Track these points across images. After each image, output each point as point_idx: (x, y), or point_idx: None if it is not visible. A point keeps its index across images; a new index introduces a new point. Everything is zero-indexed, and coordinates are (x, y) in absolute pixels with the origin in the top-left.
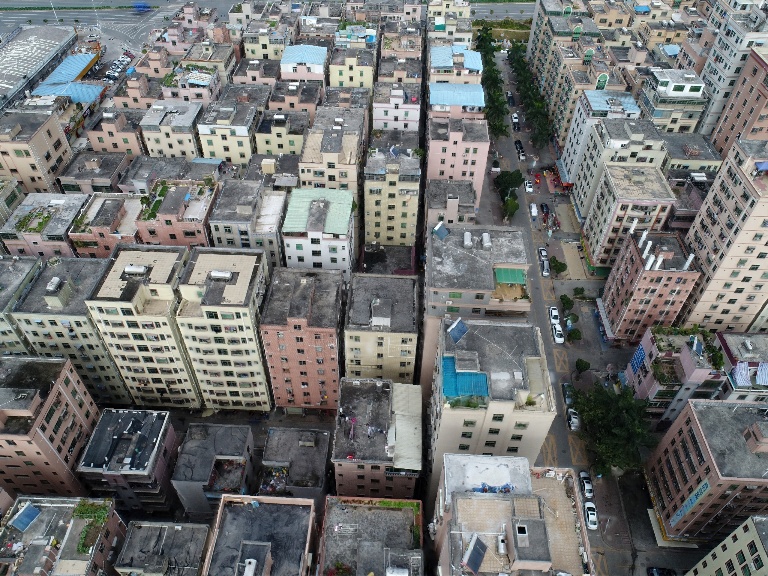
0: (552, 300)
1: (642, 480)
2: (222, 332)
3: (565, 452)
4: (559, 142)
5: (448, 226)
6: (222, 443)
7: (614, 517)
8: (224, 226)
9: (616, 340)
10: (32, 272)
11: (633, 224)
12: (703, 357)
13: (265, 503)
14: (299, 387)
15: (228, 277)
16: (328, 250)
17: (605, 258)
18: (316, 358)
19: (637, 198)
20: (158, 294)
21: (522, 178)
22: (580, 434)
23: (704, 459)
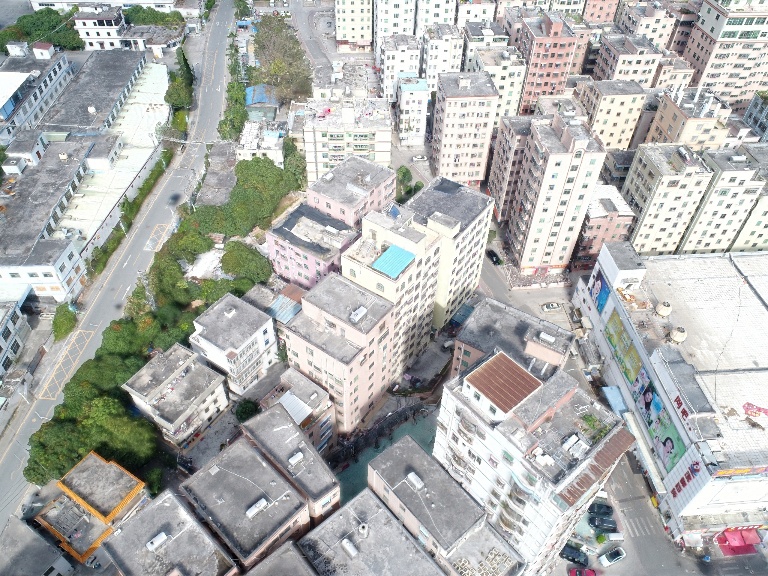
0: None
1: None
2: None
3: None
4: None
5: None
6: None
7: None
8: None
9: None
10: None
11: None
12: None
13: (640, 6)
14: (595, 20)
15: None
16: None
17: None
18: None
19: None
20: None
21: None
22: None
23: None
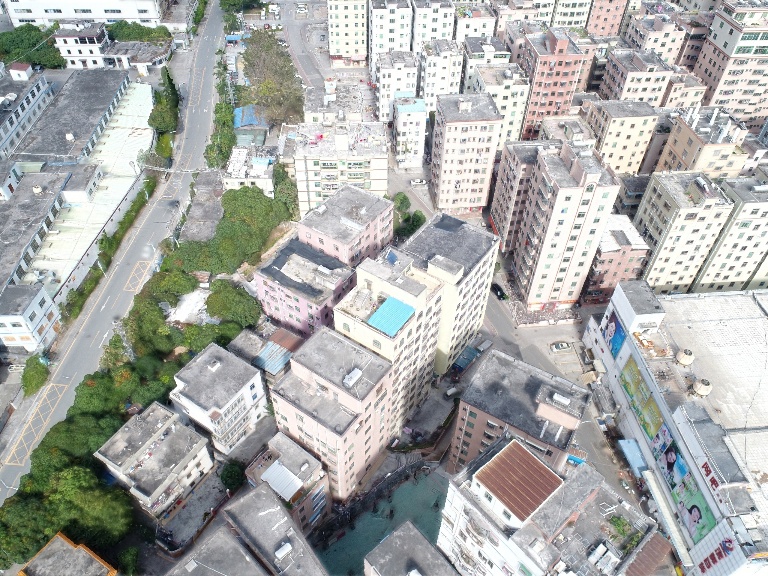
0: None
1: None
2: None
3: None
4: None
5: None
6: None
7: None
8: None
9: None
10: None
11: None
12: None
13: (647, 19)
14: (599, 31)
15: None
16: None
17: None
18: (616, 6)
19: None
20: None
21: None
22: None
23: None
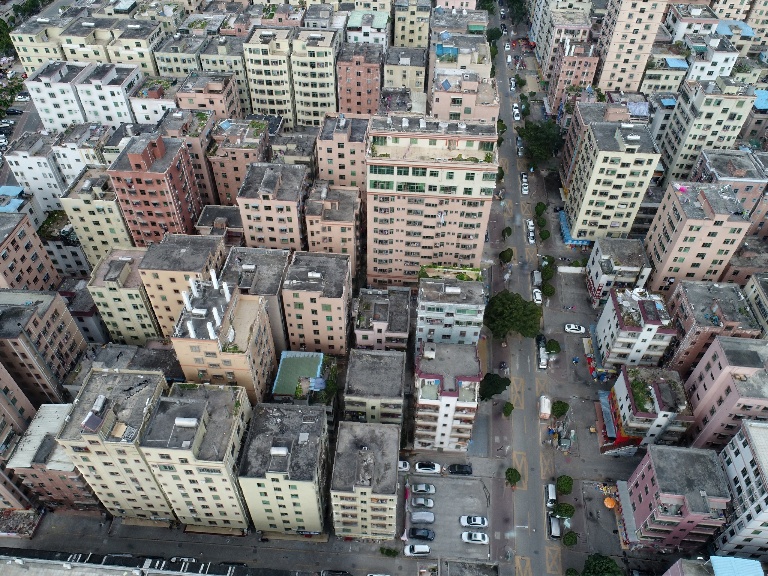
0: (515, 102)
1: (559, 178)
2: (315, 68)
3: (514, 165)
4: (530, 19)
5: (444, 10)
6: (313, 133)
7: (539, 190)
8: (313, 23)
9: (553, 117)
10: (205, 42)
11: (561, 35)
12: (592, 94)
13: None
14: None
15: (320, 37)
16: (373, 41)
17: (550, 73)
18: (367, 89)
19: (567, 24)
20: (280, 47)
21: (500, 33)
22: (522, 149)
23: (579, 124)
